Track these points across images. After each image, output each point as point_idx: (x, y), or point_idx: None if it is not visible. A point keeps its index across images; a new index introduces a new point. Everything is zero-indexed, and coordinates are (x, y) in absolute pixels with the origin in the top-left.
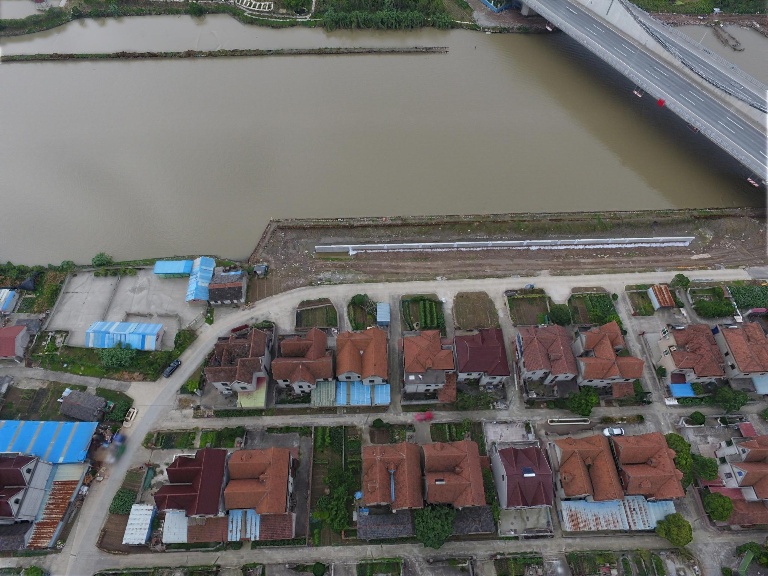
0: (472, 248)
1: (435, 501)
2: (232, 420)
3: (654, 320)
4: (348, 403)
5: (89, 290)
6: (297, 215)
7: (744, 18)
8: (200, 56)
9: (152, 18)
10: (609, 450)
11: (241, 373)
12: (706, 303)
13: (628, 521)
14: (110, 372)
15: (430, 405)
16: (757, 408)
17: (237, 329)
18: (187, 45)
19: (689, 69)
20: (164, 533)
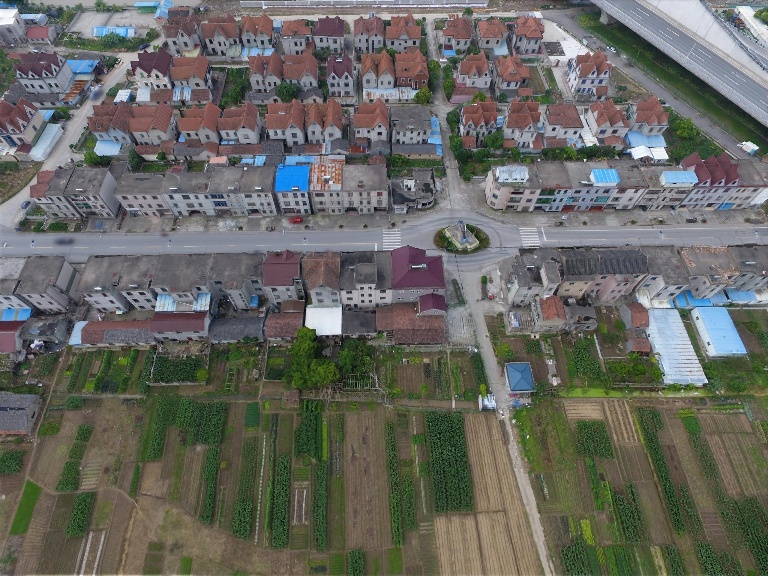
0: (343, 6)
1: (290, 83)
2: None
3: None
4: (248, 55)
5: (93, 18)
6: None
7: None
8: None
9: None
10: (391, 61)
11: (183, 29)
12: None
13: (399, 96)
14: (106, 49)
15: None
16: None
17: None
18: None
19: None
20: (137, 97)
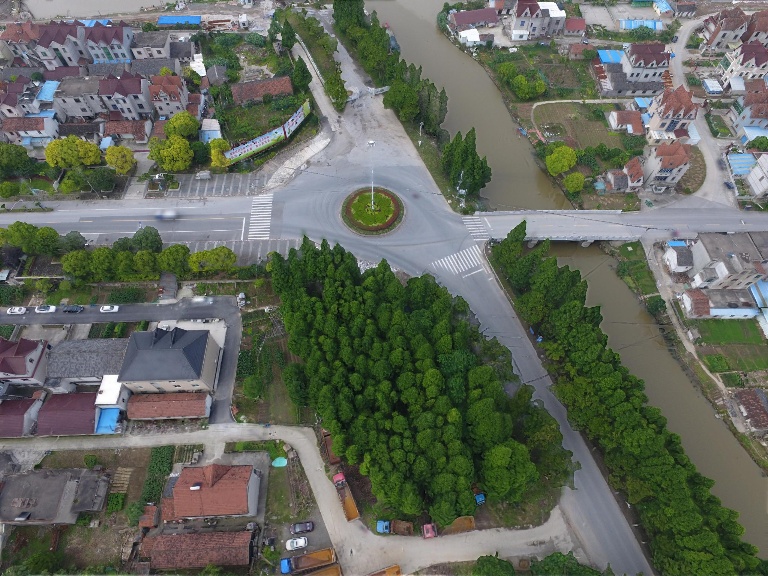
0: None
1: None
2: None
3: None
4: None
5: (593, 11)
6: None
7: None
8: None
9: None
10: None
11: None
12: None
13: None
14: (639, 41)
15: None
16: None
17: None
18: None
19: None
20: (732, 86)
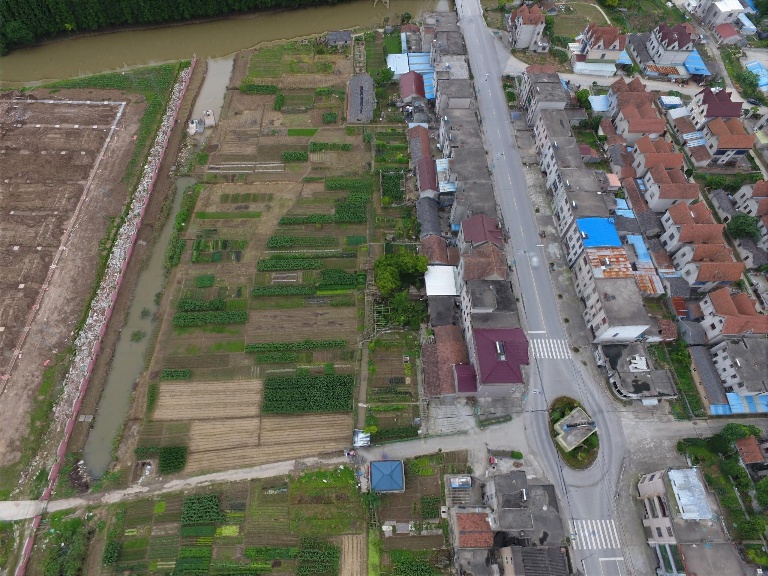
0: None
1: (760, 226)
2: None
3: None
4: None
5: None
6: None
7: None
8: None
9: None
10: None
11: None
12: None
13: None
14: (735, 79)
15: None
16: None
17: None
18: None
19: None
20: (674, 109)
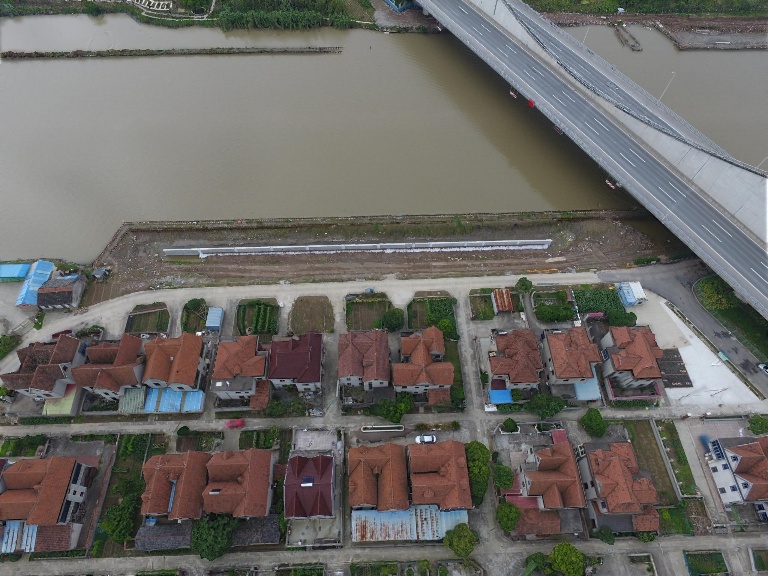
0: (326, 251)
1: None
2: (39, 428)
3: (492, 325)
4: (156, 410)
5: None
6: (153, 218)
7: (648, 18)
8: (88, 56)
9: (48, 18)
10: (402, 458)
11: (38, 380)
12: (543, 307)
13: (417, 531)
14: None
15: (244, 412)
16: (578, 414)
17: (58, 334)
18: (79, 45)
19: (564, 69)
20: None
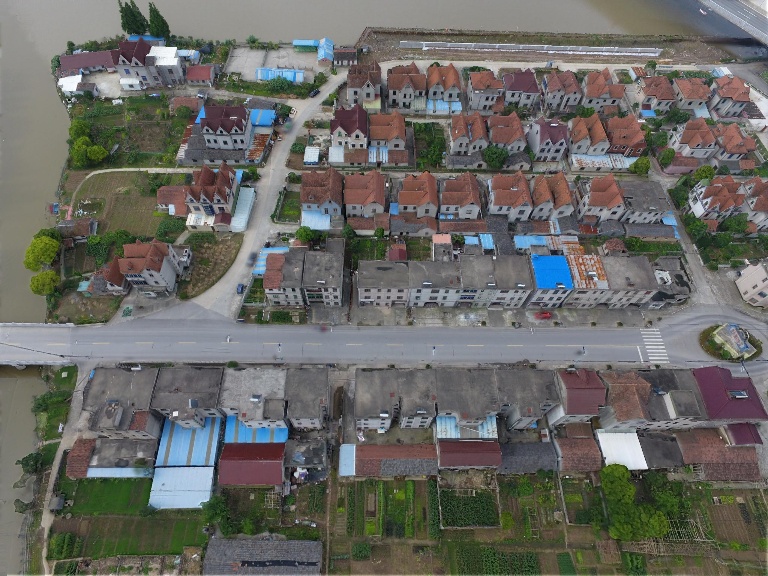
0: (508, 50)
1: (495, 146)
2: None
3: (632, 86)
4: (435, 109)
5: (247, 56)
6: (384, 26)
7: None
8: None
9: None
10: None
11: (370, 79)
12: (667, 74)
13: (612, 164)
14: (273, 94)
15: (486, 117)
16: None
17: None
18: None
19: None
20: (329, 157)
